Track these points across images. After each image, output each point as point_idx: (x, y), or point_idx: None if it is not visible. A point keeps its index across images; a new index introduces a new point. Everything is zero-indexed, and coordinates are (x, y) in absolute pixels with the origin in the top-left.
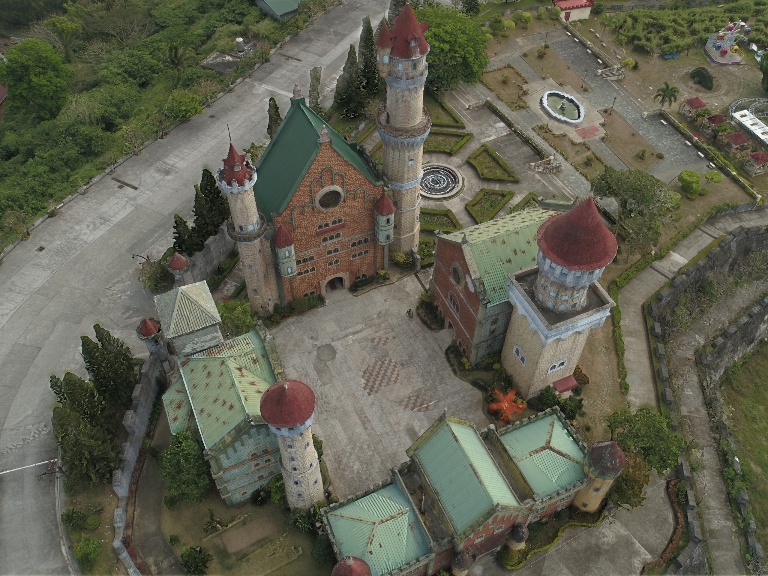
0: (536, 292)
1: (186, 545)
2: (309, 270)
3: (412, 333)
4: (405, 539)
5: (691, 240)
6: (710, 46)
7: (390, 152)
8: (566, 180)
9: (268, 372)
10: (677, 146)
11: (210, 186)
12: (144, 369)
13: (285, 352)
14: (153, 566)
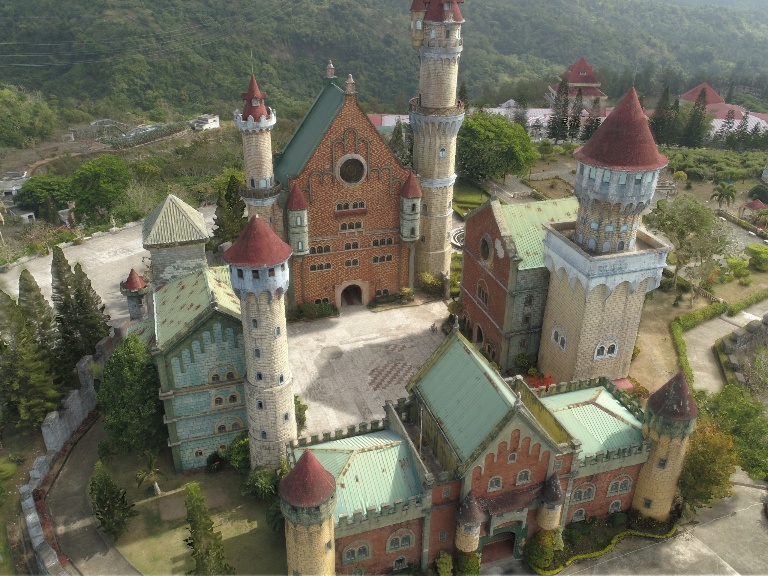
0: (575, 236)
1: None
2: (324, 266)
3: (434, 344)
4: (392, 477)
5: (766, 305)
6: (766, 176)
7: (420, 140)
8: None
9: None
10: (740, 235)
11: (235, 195)
12: (118, 325)
13: None
14: (61, 525)
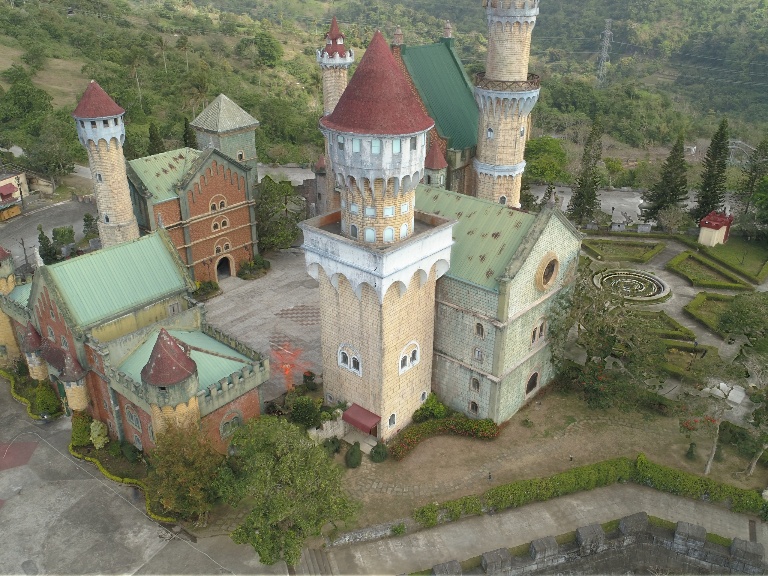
0: None
1: None
2: None
3: None
4: None
5: None
6: None
7: None
8: None
9: None
10: None
11: None
12: None
13: (300, 266)
14: None
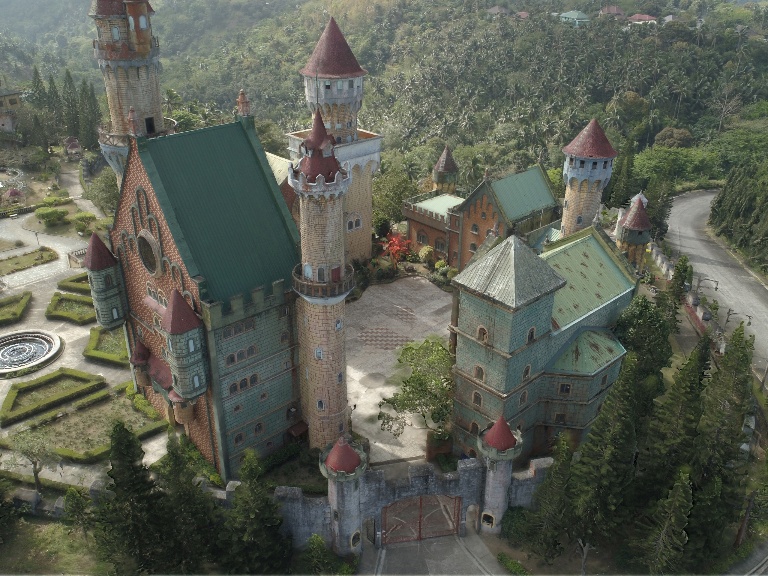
0: (343, 142)
1: None
2: None
3: None
4: None
5: None
6: None
7: None
8: (21, 281)
9: None
10: None
11: None
12: (550, 461)
13: (392, 414)
14: None
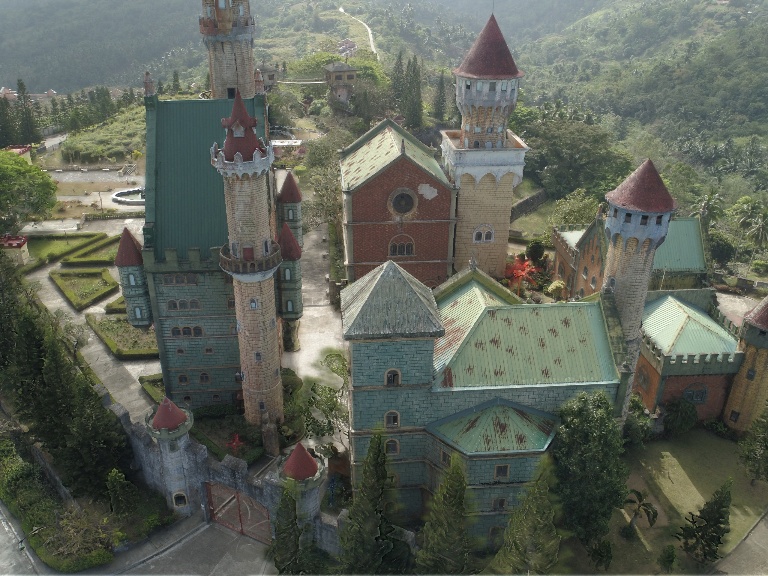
0: (481, 147)
1: (657, 574)
2: None
3: None
4: (698, 314)
5: None
6: None
7: None
8: None
9: (504, 303)
10: None
11: None
12: None
13: None
14: None
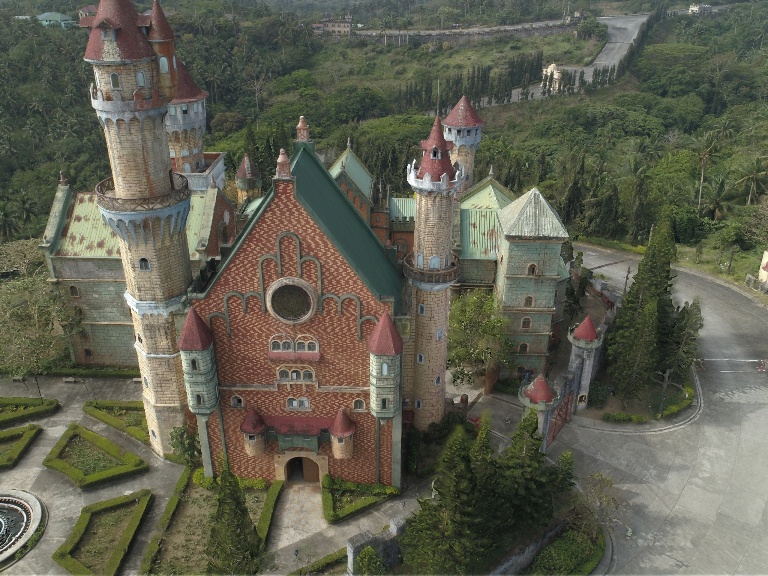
0: None
1: None
2: None
3: None
4: None
5: None
6: None
7: None
8: None
9: None
10: None
11: None
12: None
13: None
14: (588, 295)
